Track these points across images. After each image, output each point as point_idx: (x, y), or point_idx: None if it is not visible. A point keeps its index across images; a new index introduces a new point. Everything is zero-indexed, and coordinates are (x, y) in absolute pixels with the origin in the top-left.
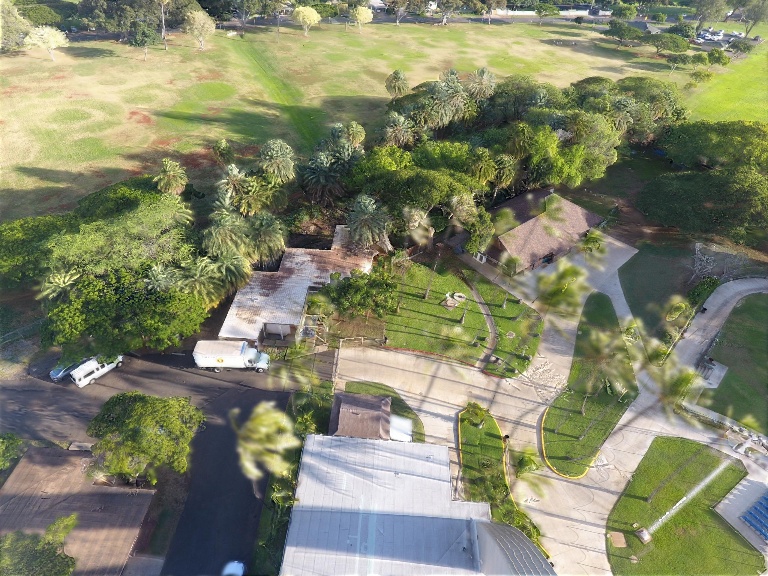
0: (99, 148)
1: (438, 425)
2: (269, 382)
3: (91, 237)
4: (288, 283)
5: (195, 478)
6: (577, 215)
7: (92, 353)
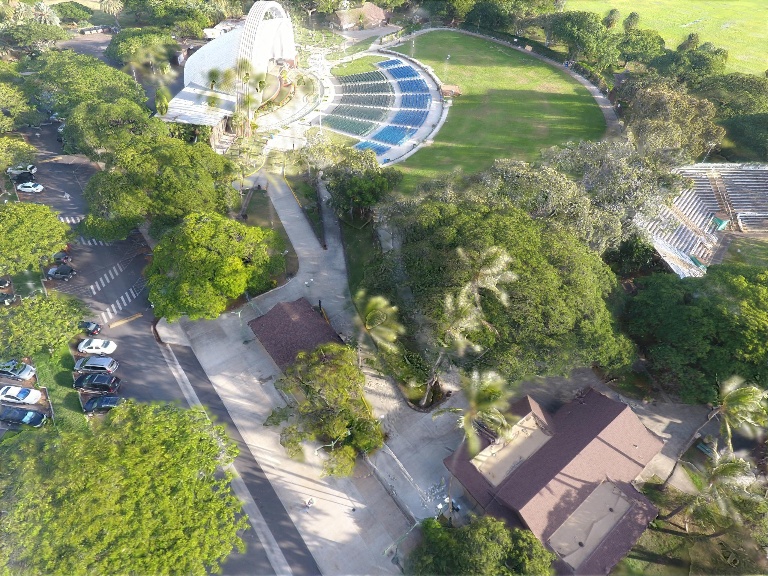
0: None
1: None
2: None
3: None
4: (242, 21)
5: None
6: (380, 12)
7: (168, 24)
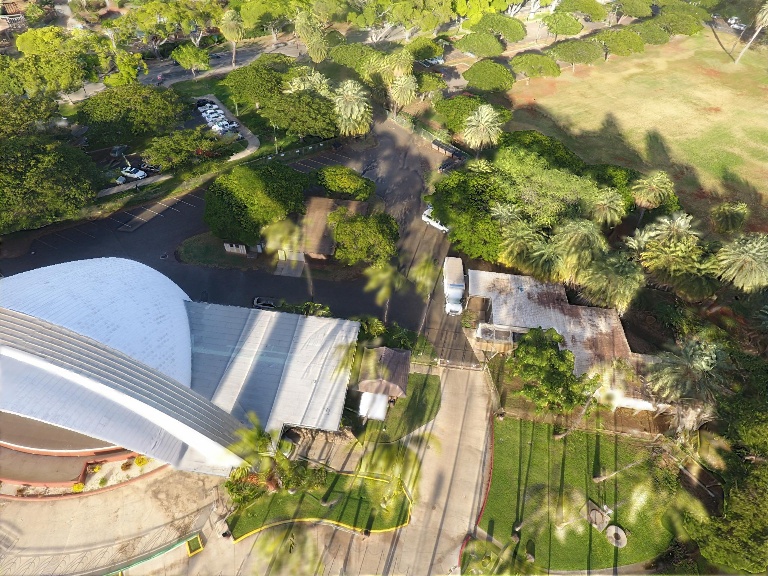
0: (725, 165)
1: (388, 458)
2: (435, 317)
3: (525, 160)
4: (554, 313)
5: (351, 283)
6: None
7: None
